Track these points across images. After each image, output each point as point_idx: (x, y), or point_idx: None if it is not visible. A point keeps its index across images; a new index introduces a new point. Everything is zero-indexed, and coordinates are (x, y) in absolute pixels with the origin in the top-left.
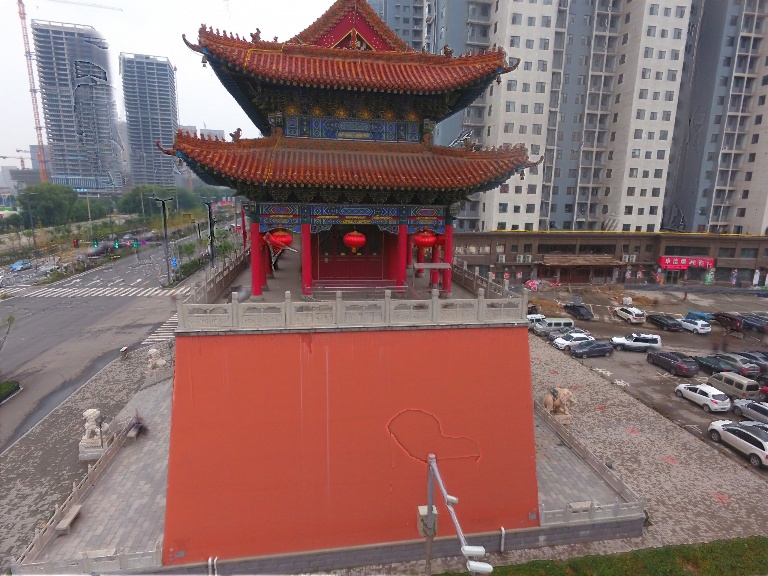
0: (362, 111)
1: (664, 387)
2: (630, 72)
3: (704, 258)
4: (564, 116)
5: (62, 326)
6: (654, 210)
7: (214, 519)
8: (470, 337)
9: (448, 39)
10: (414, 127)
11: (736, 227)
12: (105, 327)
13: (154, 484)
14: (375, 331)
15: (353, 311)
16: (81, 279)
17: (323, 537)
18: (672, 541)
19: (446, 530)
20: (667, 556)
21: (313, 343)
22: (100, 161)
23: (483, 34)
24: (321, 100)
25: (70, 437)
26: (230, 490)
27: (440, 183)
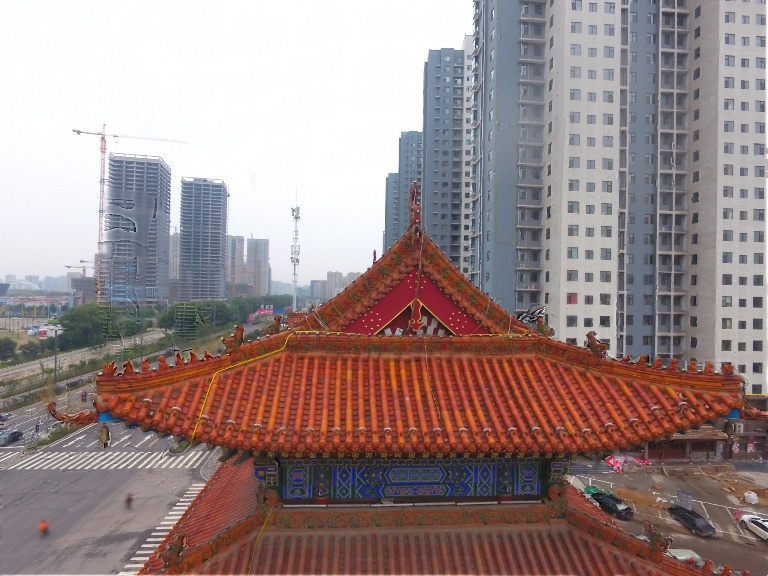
0: None
1: None
2: (707, 212)
3: None
4: (632, 257)
5: (27, 537)
6: (758, 367)
7: None
8: None
9: (497, 182)
10: (529, 470)
11: None
12: (78, 540)
13: None
14: None
15: None
16: (85, 435)
17: None
18: None
19: None
20: None
21: None
22: (111, 322)
23: (535, 176)
24: None
25: None
26: None
27: None
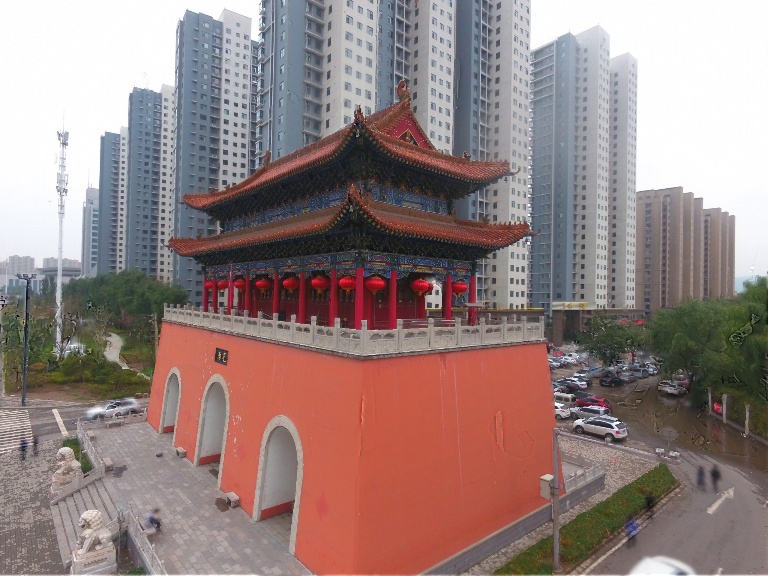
0: (415, 188)
1: None
2: None
3: None
4: None
5: None
6: None
7: (389, 543)
8: (522, 351)
9: (287, 142)
10: (444, 204)
11: (495, 303)
12: None
13: (242, 562)
14: (479, 349)
15: (465, 334)
16: None
17: (461, 538)
18: (620, 486)
19: (524, 510)
20: (630, 491)
21: (447, 361)
22: None
23: None
24: (395, 176)
25: (16, 572)
26: (401, 508)
27: (489, 243)
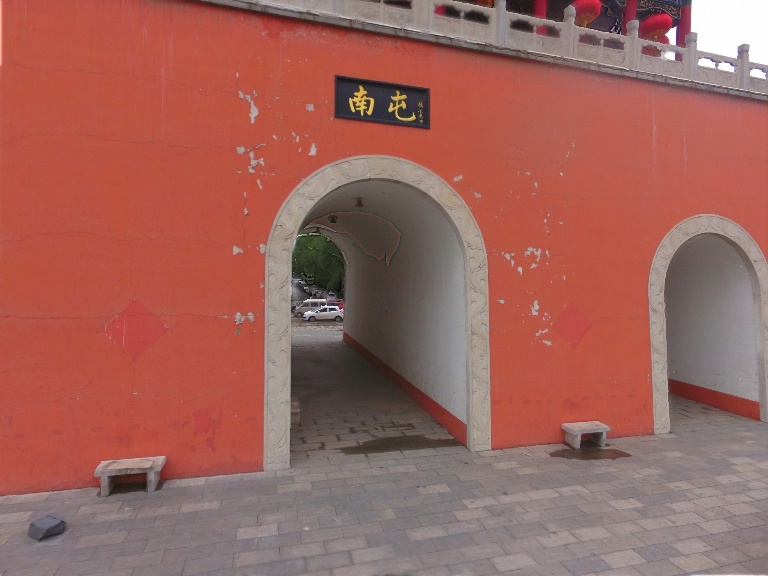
0: None
1: (294, 321)
2: None
3: None
4: None
5: None
6: None
7: None
8: None
9: None
10: None
11: None
12: None
13: None
14: None
15: None
16: None
17: None
18: None
19: None
20: None
21: None
22: None
23: None
24: None
25: None
26: None
27: None
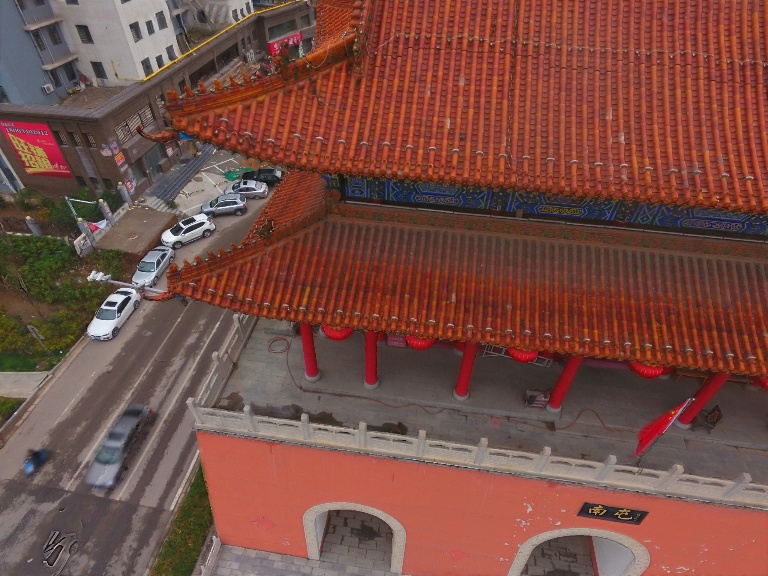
0: None
1: None
2: None
3: (296, 33)
4: None
5: None
6: None
7: None
8: None
9: None
10: None
11: None
12: None
13: None
14: None
15: None
16: None
17: None
18: None
19: None
20: None
21: None
22: None
23: None
24: None
25: None
26: None
27: None
